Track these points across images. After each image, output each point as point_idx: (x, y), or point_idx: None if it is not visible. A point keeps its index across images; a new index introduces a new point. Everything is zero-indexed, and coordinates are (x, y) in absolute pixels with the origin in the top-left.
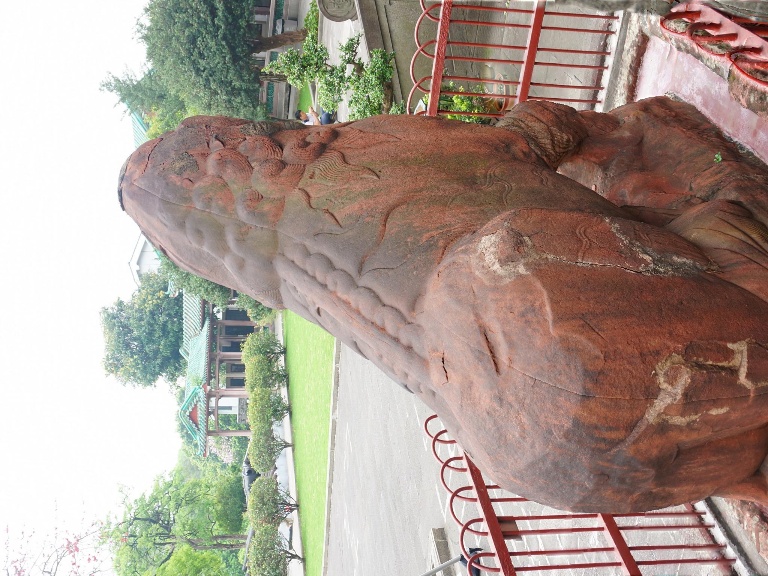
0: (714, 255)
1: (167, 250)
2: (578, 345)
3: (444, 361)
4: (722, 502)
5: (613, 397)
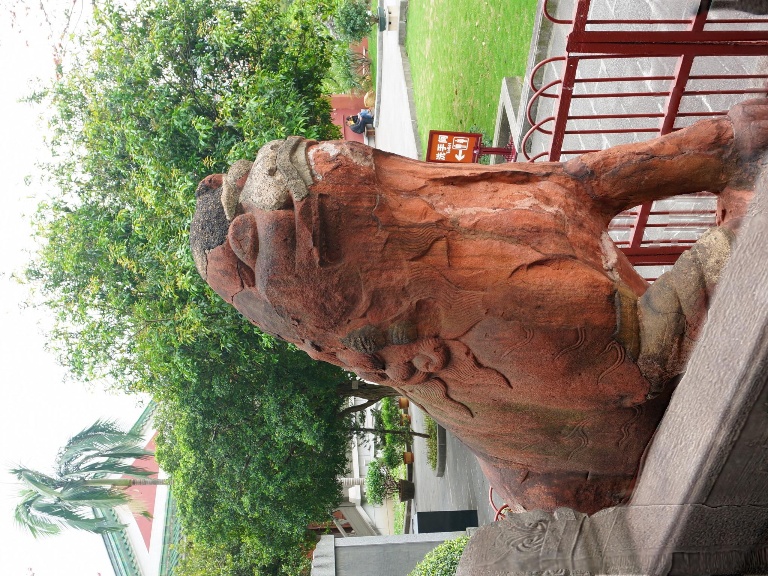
0: None
1: None
2: None
3: None
4: None
5: None
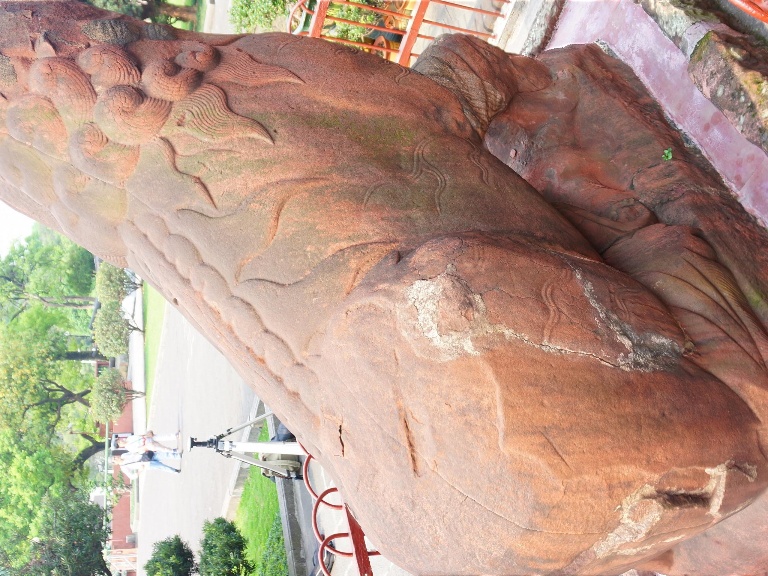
0: (686, 322)
1: None
2: (534, 470)
3: (342, 430)
4: None
5: (563, 532)
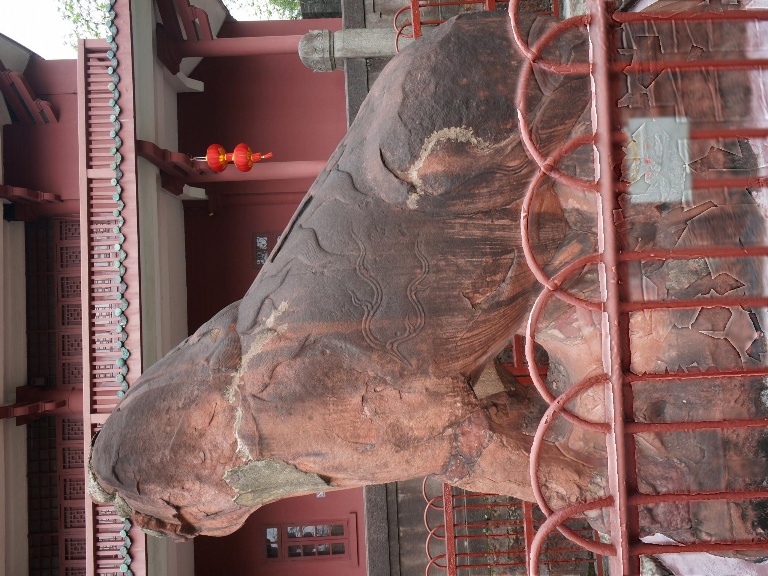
0: None
1: None
2: None
3: None
4: None
5: None
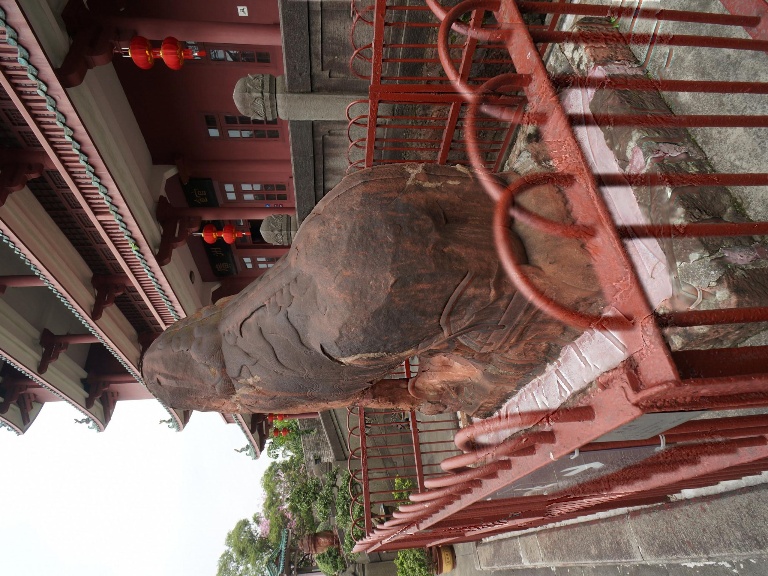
0: None
1: (161, 377)
2: None
3: None
4: (612, 489)
5: (382, 178)
